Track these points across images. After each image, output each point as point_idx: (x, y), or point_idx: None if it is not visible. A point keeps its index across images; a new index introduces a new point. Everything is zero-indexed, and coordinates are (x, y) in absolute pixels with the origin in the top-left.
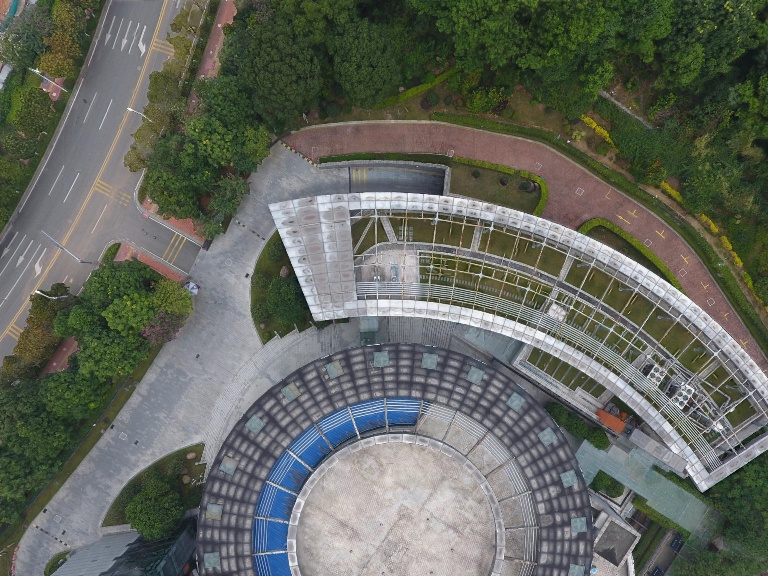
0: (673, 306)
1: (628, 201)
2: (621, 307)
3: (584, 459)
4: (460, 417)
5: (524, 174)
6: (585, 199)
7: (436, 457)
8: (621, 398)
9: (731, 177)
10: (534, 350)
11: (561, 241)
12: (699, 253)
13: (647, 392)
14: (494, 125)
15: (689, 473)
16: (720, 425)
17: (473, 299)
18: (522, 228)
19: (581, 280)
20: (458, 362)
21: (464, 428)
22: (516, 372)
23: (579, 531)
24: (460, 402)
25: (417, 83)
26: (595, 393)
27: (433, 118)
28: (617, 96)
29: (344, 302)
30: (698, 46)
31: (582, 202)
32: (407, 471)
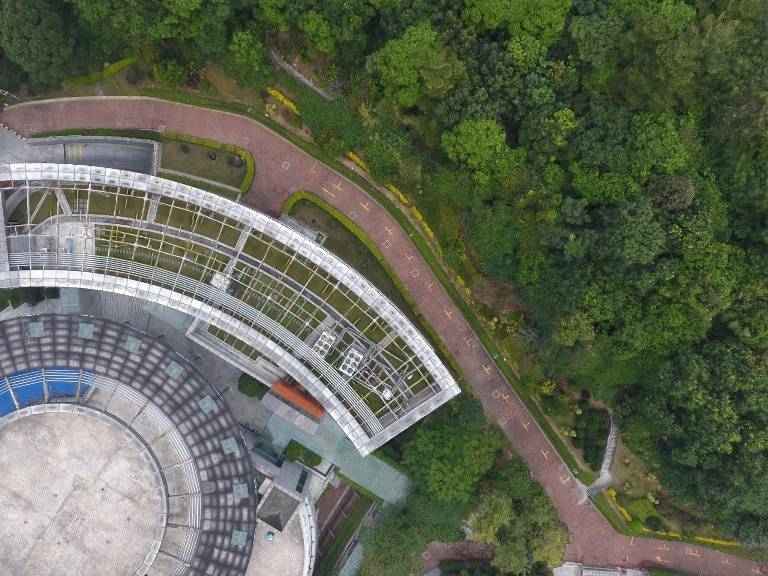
0: (330, 273)
1: (333, 174)
2: (300, 277)
3: (276, 429)
4: (121, 386)
5: (230, 148)
6: (291, 173)
7: (110, 427)
8: (280, 365)
9: (399, 147)
10: None
11: (216, 210)
12: (400, 225)
13: (306, 359)
14: (198, 100)
15: (350, 438)
16: None
17: (128, 269)
18: (176, 198)
19: (259, 250)
20: (116, 331)
21: (125, 397)
22: None
23: (241, 497)
24: (119, 371)
25: (117, 58)
26: None
27: (141, 94)
28: (299, 68)
29: None
30: (312, 13)
31: (288, 176)
32: (81, 442)
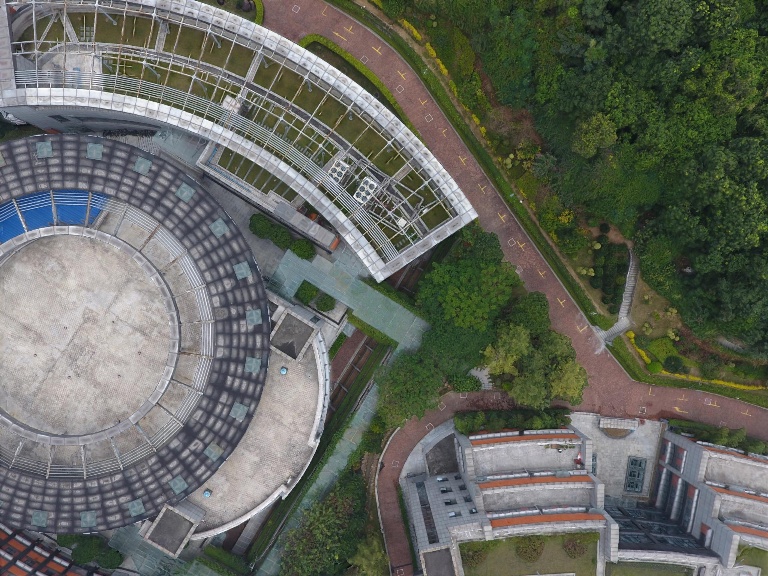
0: (344, 94)
1: (344, 17)
2: (312, 108)
3: (288, 269)
4: (131, 210)
5: None
6: (301, 16)
7: (120, 259)
8: (293, 188)
9: None
10: (224, 153)
11: (226, 27)
12: (413, 67)
13: (320, 182)
14: None
15: (365, 263)
16: (403, 220)
17: (137, 87)
18: (185, 14)
19: (270, 81)
20: (125, 153)
21: (135, 221)
22: (227, 188)
23: (254, 324)
24: (129, 194)
25: None
26: (288, 196)
27: None
28: None
29: (2, 90)
30: None
31: (299, 20)
32: (90, 273)
